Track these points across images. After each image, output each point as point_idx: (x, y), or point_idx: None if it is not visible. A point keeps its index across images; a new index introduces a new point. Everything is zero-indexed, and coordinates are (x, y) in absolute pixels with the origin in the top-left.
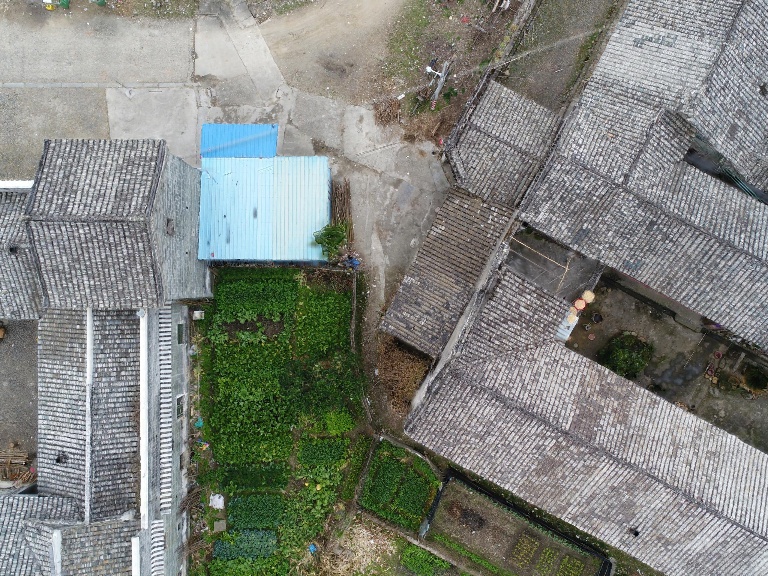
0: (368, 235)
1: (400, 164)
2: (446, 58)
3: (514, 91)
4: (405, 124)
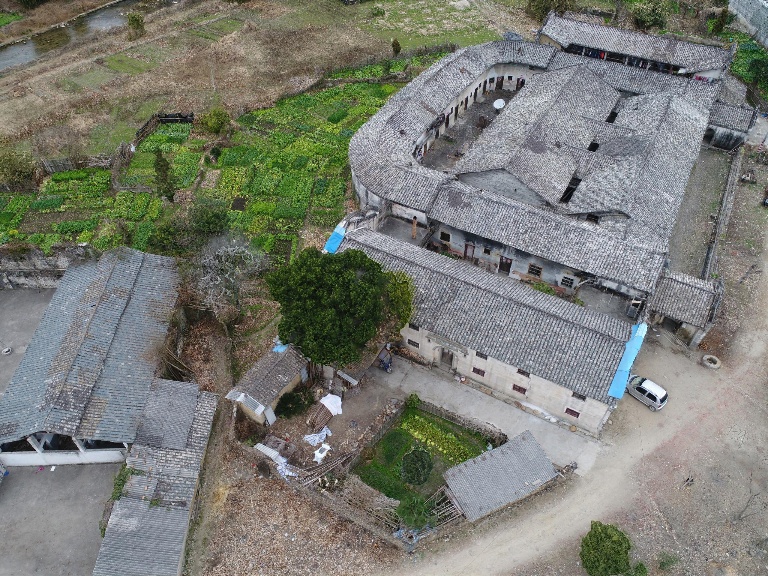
0: (762, 122)
1: (762, 139)
2: (761, 167)
3: (721, 156)
4: (767, 150)
